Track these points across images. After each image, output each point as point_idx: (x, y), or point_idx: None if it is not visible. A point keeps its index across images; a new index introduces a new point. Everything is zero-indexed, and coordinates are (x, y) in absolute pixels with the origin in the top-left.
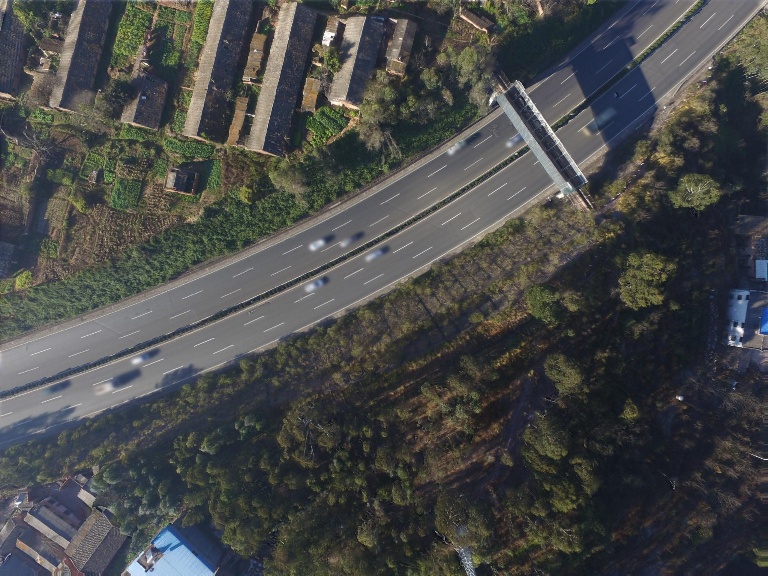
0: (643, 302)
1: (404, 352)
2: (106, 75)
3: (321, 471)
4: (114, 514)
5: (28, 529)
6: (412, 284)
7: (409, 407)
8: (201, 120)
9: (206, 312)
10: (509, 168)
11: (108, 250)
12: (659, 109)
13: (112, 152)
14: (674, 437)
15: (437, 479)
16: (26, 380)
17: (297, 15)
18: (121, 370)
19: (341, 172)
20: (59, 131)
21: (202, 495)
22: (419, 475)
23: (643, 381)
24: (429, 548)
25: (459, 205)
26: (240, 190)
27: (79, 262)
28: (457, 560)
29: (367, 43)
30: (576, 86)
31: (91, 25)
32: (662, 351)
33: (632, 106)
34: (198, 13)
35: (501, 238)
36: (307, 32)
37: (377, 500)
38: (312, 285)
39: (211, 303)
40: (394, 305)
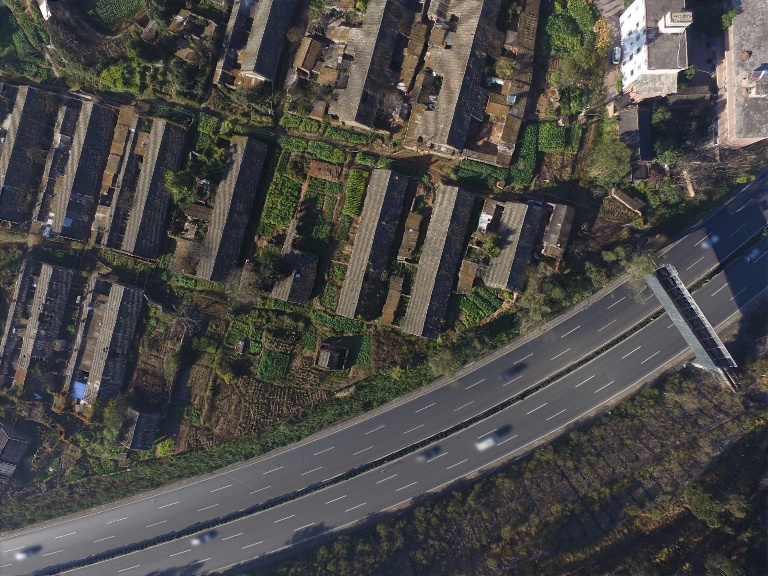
0: None
1: (558, 540)
2: (252, 243)
3: None
4: None
5: None
6: (553, 455)
7: None
8: (358, 302)
9: (338, 469)
10: (643, 331)
11: (255, 423)
12: None
13: (258, 321)
14: None
15: None
16: (154, 533)
17: (458, 200)
18: (251, 525)
19: None
20: (202, 297)
21: None
22: None
23: None
24: None
25: (593, 367)
26: (393, 370)
27: (224, 432)
28: None
29: (527, 230)
30: (710, 249)
31: (242, 197)
32: None
33: (765, 271)
34: (351, 188)
35: (642, 410)
36: (465, 215)
37: None
38: (445, 444)
39: (343, 460)
40: (534, 474)
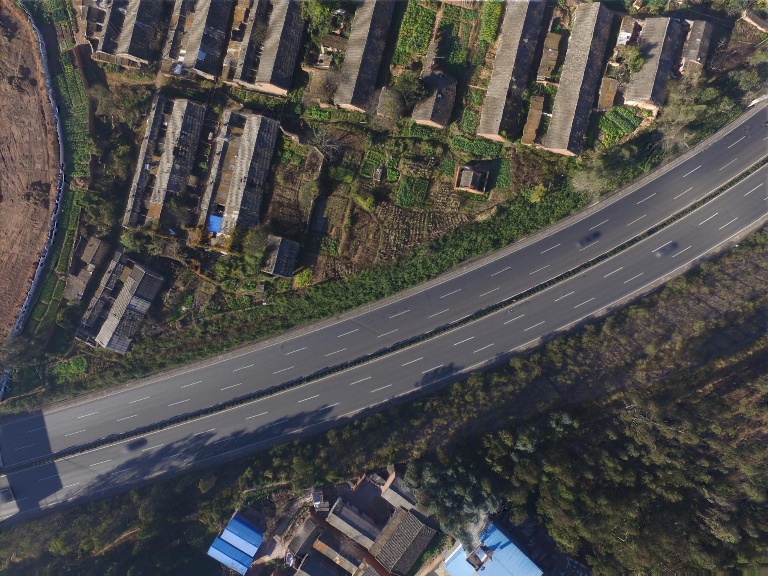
0: None
1: (707, 350)
2: (387, 73)
3: (655, 468)
4: (421, 513)
5: (325, 529)
6: None
7: None
8: (502, 119)
9: (465, 311)
10: (764, 169)
11: (395, 248)
12: None
13: (394, 150)
14: None
15: None
16: (282, 379)
17: (599, 15)
18: (379, 369)
19: None
20: (337, 128)
21: (524, 493)
22: None
23: None
24: None
25: (716, 205)
26: (535, 189)
27: (363, 260)
28: None
29: (668, 44)
30: None
31: (379, 22)
32: None
33: None
34: (488, 12)
35: None
36: (605, 32)
37: (721, 496)
38: (571, 284)
39: (470, 302)
40: (667, 304)
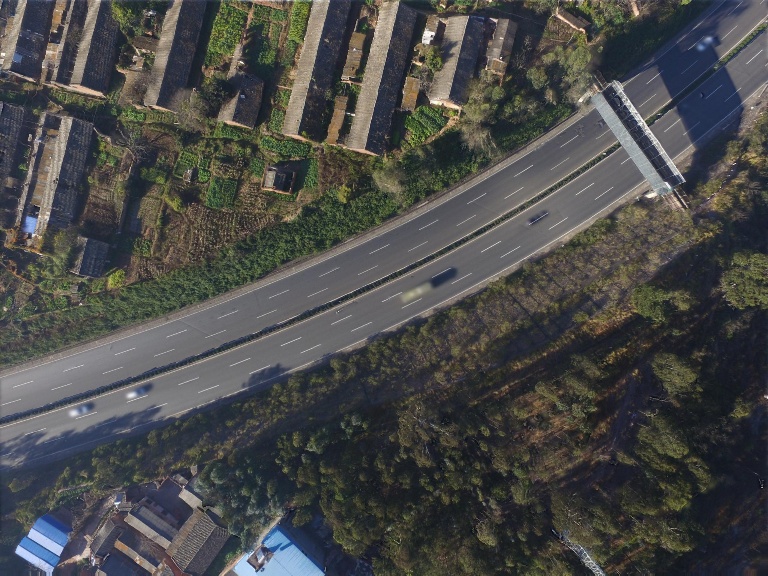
0: (752, 301)
1: (507, 351)
2: (200, 73)
3: (434, 470)
4: (216, 514)
5: (127, 529)
6: (505, 283)
7: (514, 406)
8: (302, 119)
9: (293, 311)
10: (596, 168)
11: (204, 249)
12: (746, 109)
13: (206, 151)
14: (762, 436)
15: (544, 478)
16: (111, 380)
17: (399, 14)
18: (207, 370)
19: (433, 171)
20: (151, 130)
21: (310, 495)
22: (538, 474)
23: (734, 380)
24: (545, 547)
25: (546, 205)
26: (339, 189)
27: (173, 261)
28: (576, 559)
29: (469, 42)
30: (662, 86)
31: (187, 23)
32: (751, 350)
33: (718, 106)
34: (295, 12)
35: (594, 238)
36: (408, 31)
37: (493, 499)
38: (399, 284)
39: (298, 302)
40: (486, 304)
